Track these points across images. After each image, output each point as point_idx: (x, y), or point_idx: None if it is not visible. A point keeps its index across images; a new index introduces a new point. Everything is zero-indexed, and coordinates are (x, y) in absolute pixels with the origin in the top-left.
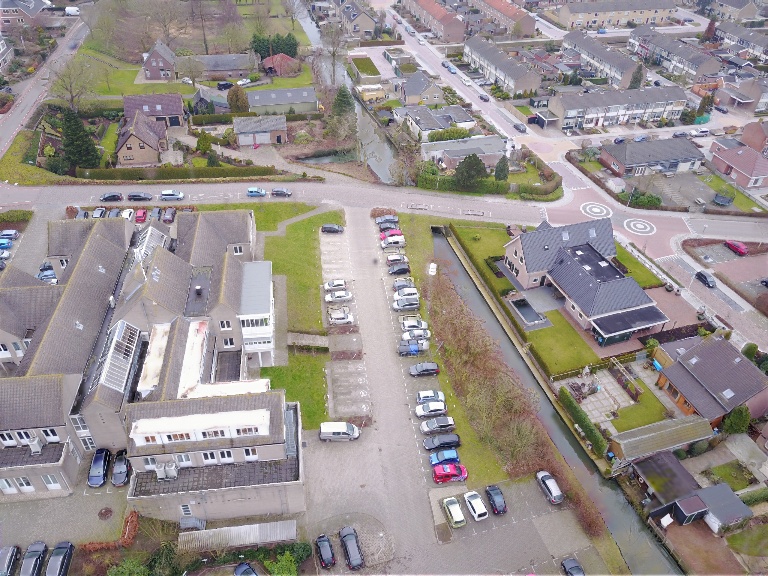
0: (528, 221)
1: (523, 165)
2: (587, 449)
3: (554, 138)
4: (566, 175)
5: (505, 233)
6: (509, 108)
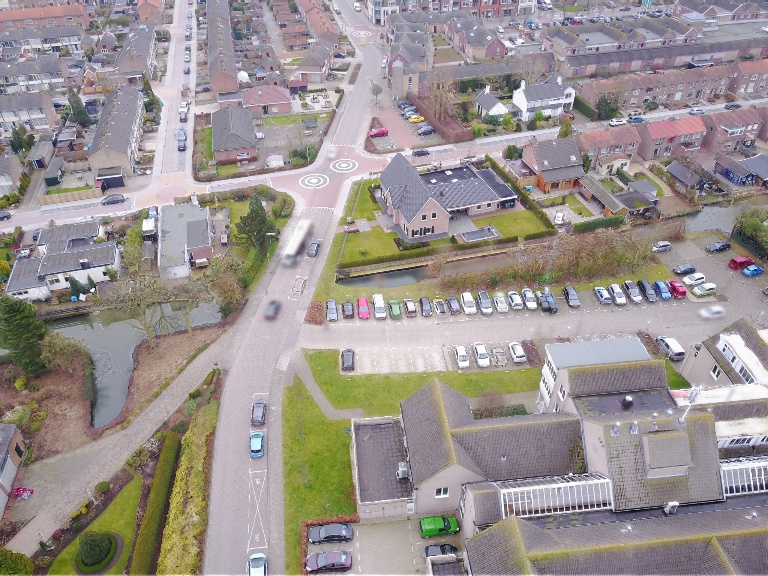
0: (331, 219)
1: (219, 206)
2: None
3: (152, 182)
4: (240, 187)
5: (354, 234)
6: (53, 200)
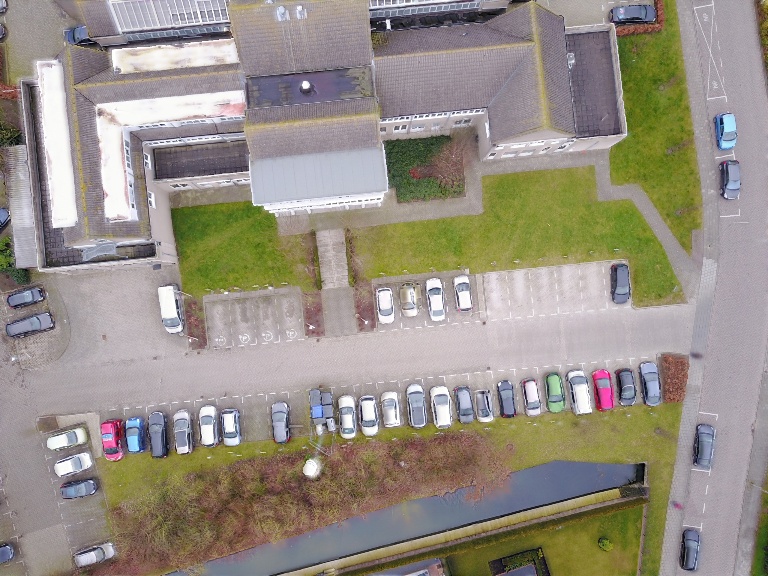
0: None
1: None
2: None
3: None
4: None
5: None
6: None
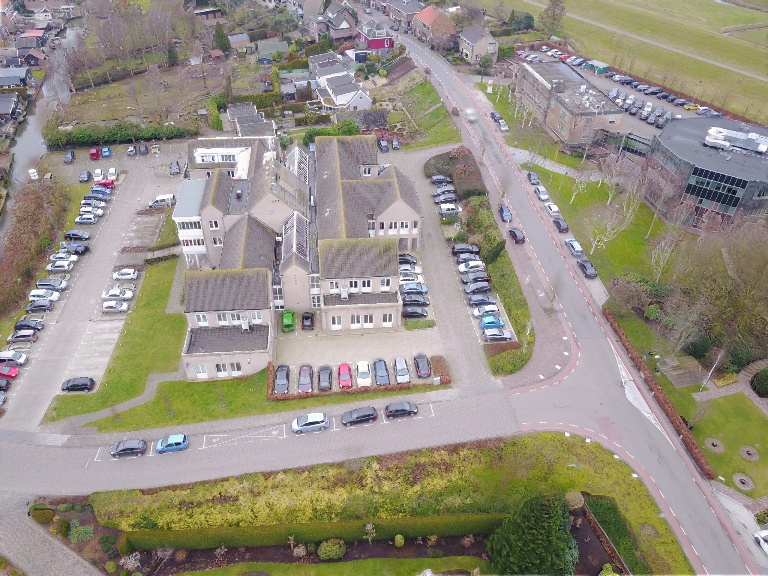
0: None
1: None
2: (3, 200)
3: None
4: None
5: None
6: None
